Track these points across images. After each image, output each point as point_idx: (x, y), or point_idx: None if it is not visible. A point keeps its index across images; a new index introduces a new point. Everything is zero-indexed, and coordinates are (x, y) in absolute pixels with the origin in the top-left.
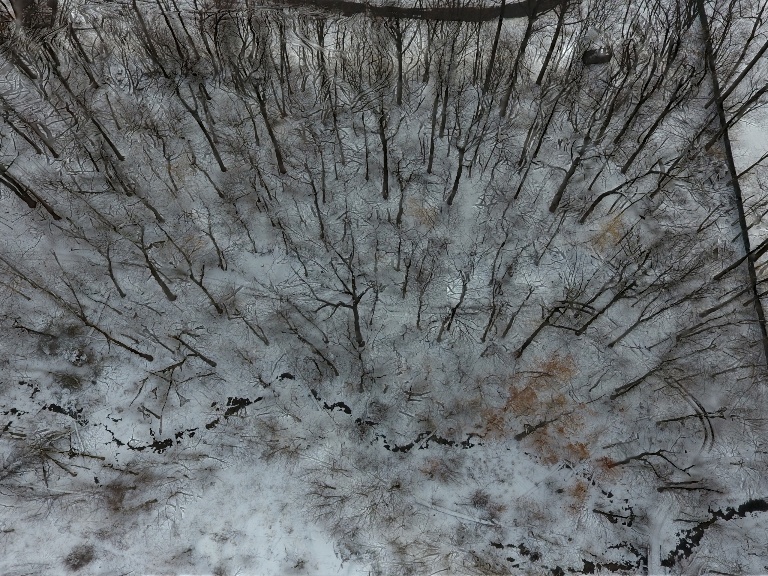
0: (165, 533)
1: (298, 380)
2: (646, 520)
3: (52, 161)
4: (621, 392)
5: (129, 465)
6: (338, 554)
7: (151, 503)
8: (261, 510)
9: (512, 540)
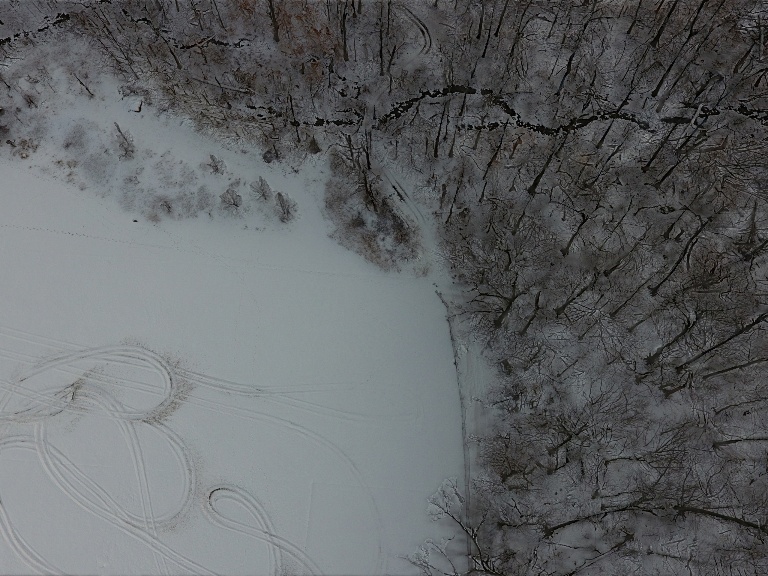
0: None
1: (113, 3)
2: (367, 91)
3: None
4: None
5: None
6: (121, 92)
7: None
8: (66, 65)
9: (263, 103)
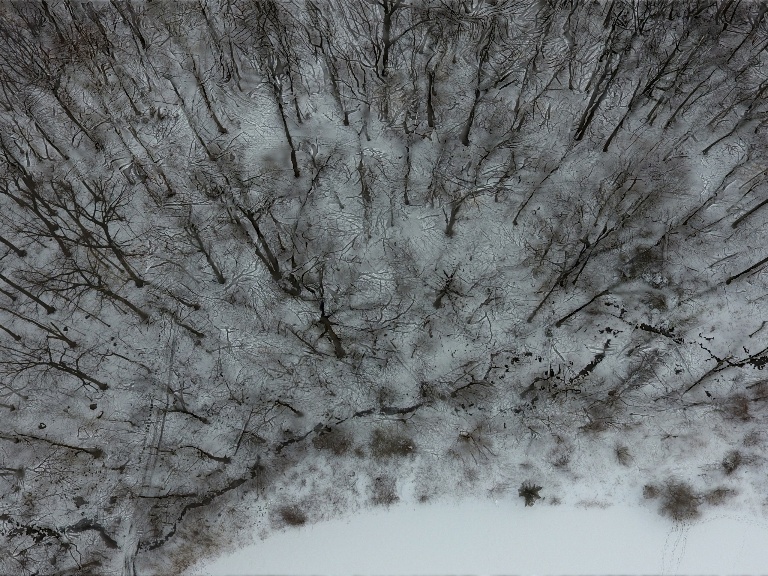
0: None
1: None
2: None
3: (585, 96)
4: None
5: (736, 380)
6: None
7: None
8: None
9: None
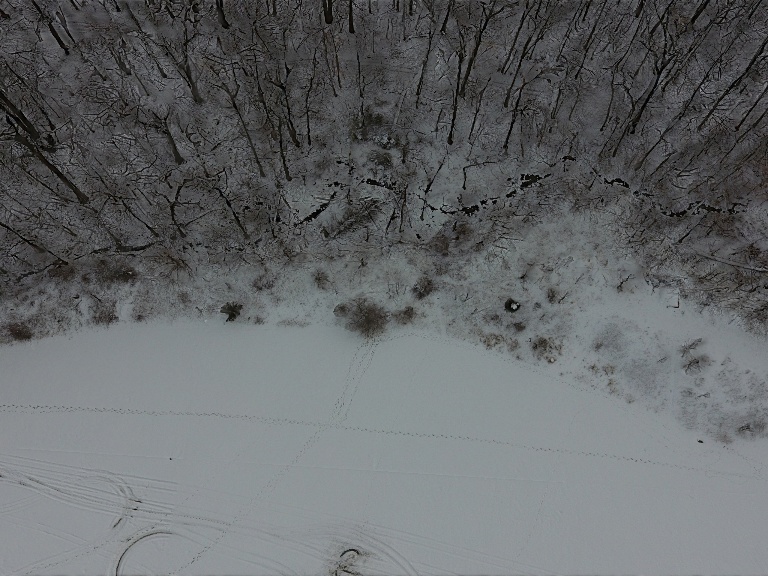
0: (496, 267)
1: (579, 161)
2: None
3: None
4: None
5: (445, 224)
6: (649, 282)
7: None
8: (577, 249)
9: None
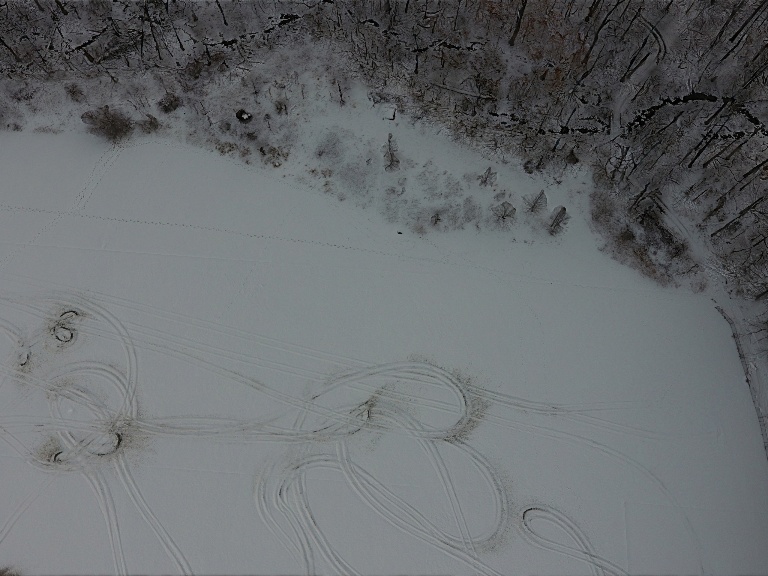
0: (236, 85)
1: None
2: (610, 98)
3: None
4: (593, 2)
5: (204, 54)
6: (371, 98)
7: (225, 65)
8: (311, 70)
9: (505, 110)
